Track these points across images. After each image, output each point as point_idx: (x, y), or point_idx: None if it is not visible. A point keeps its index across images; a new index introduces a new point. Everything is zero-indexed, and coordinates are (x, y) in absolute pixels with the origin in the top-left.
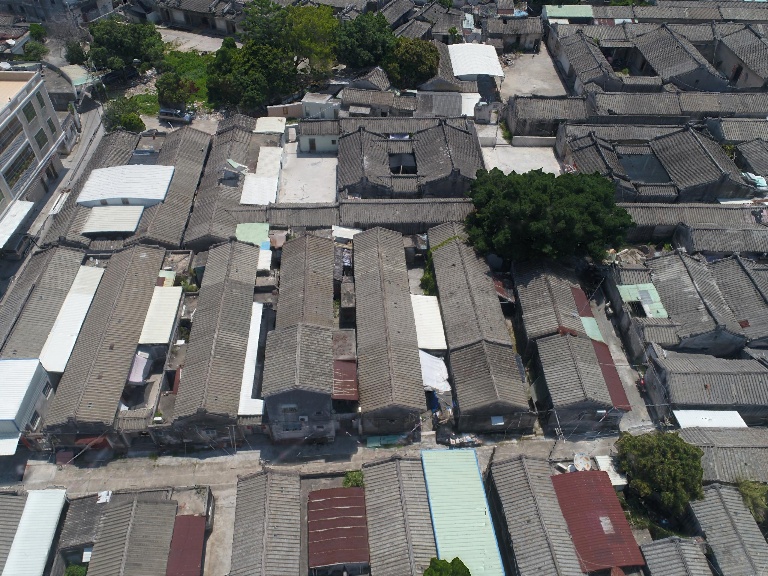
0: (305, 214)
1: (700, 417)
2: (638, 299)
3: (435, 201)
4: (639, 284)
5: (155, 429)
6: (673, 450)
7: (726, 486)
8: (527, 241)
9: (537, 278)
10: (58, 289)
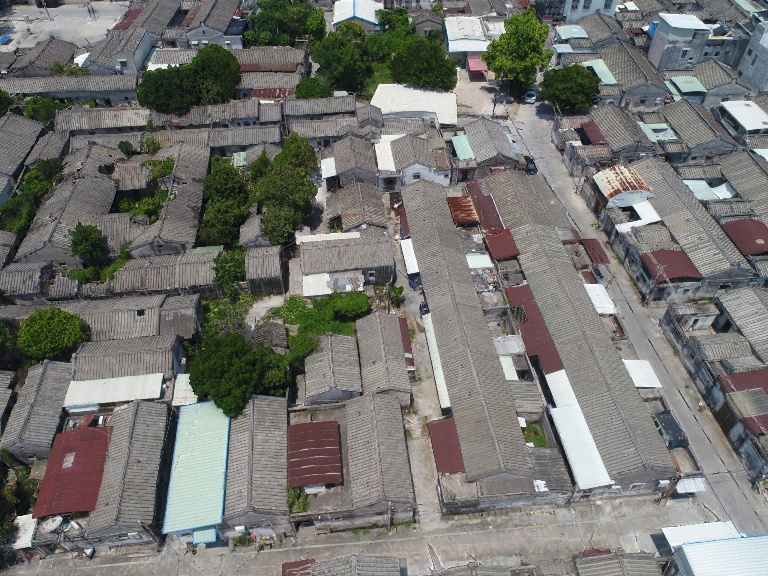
0: None
1: None
2: None
3: None
4: None
5: (528, 569)
6: None
7: None
8: None
9: None
10: None
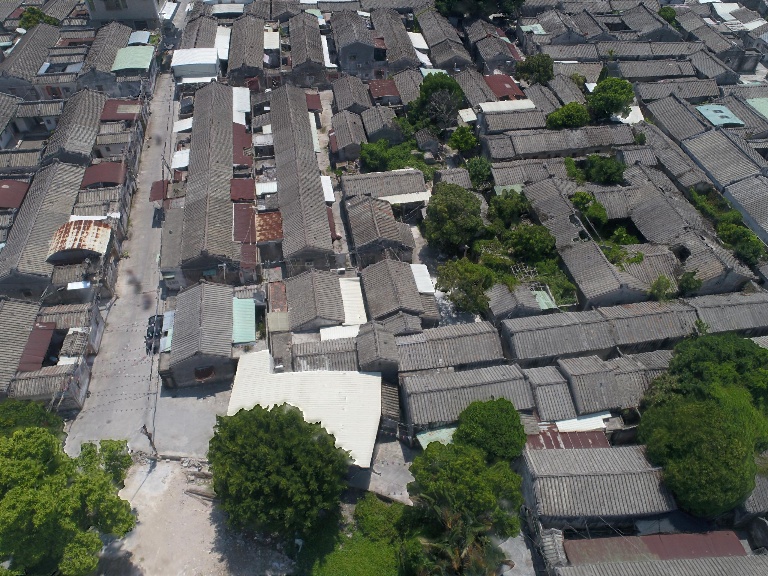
0: (340, 5)
1: None
2: (531, 30)
3: None
4: (532, 25)
5: (284, 75)
6: (539, 57)
7: None
8: (469, 3)
9: (476, 22)
10: (211, 32)
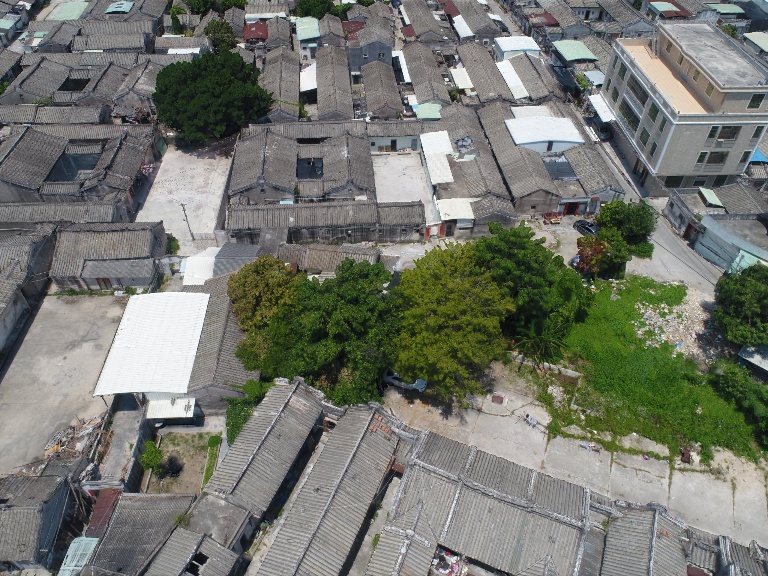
0: None
1: (187, 52)
2: None
3: (289, 124)
4: None
5: None
6: None
7: (198, 35)
8: None
9: None
10: None
